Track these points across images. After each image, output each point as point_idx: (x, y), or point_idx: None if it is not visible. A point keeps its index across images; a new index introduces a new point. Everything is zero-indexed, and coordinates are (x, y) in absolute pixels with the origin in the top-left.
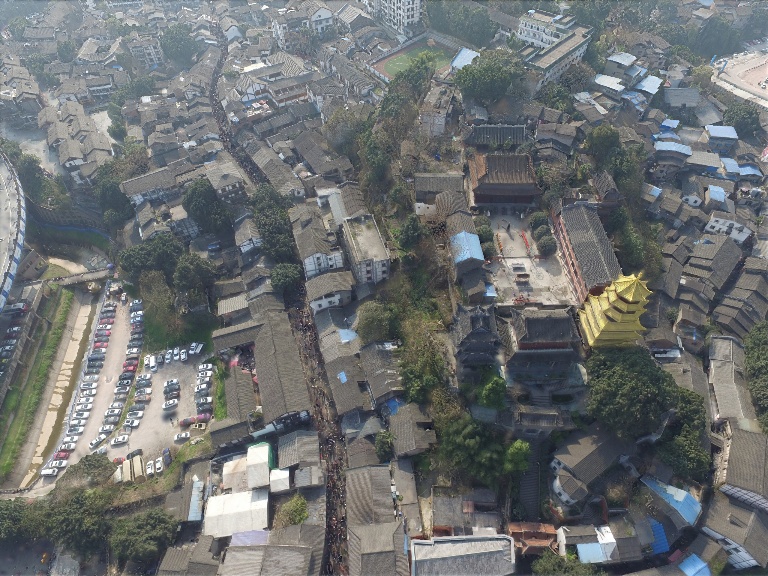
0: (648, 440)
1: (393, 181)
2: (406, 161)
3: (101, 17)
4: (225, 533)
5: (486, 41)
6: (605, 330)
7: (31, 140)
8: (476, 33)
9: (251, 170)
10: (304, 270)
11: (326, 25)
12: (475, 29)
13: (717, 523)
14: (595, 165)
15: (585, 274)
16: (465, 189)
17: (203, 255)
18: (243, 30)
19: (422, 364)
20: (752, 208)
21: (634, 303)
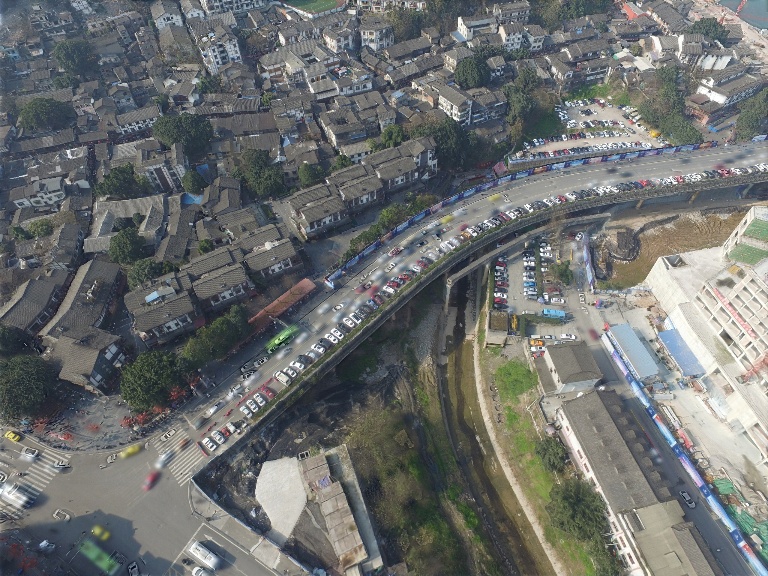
0: None
1: None
2: None
3: None
4: (652, 65)
5: None
6: None
7: (331, 249)
8: None
9: None
10: None
11: None
12: None
13: None
14: None
15: None
16: None
17: None
18: (165, 101)
19: None
20: None
21: None
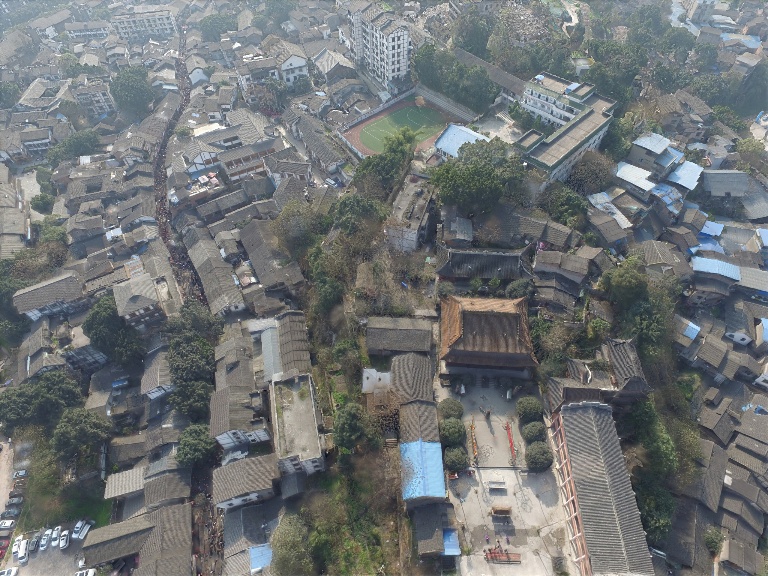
0: None
1: (344, 319)
2: (360, 298)
3: (59, 50)
4: None
5: (484, 107)
6: None
7: None
8: (472, 97)
9: (188, 265)
10: None
11: (299, 74)
12: (471, 92)
13: None
14: (612, 319)
15: (590, 544)
16: (436, 340)
17: (102, 400)
18: (209, 73)
19: None
20: None
21: None
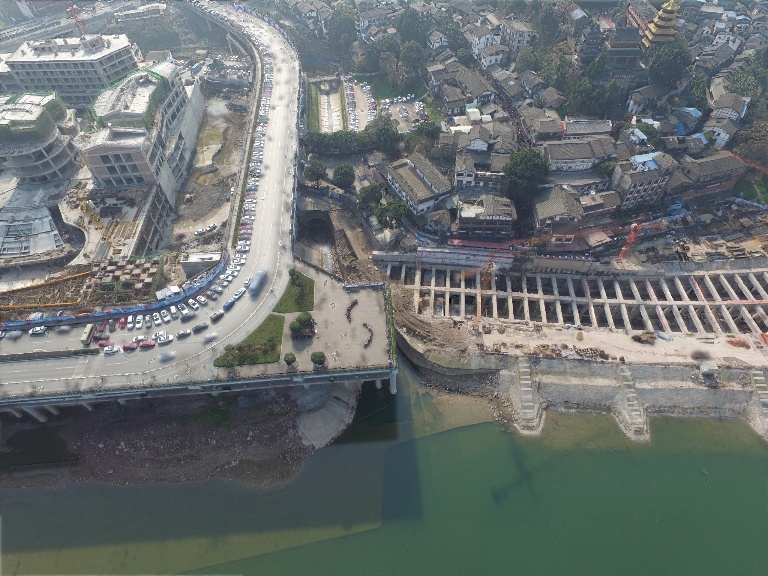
0: (676, 94)
1: (526, 5)
2: None
3: None
4: None
5: None
6: (656, 33)
7: None
8: None
9: None
10: (473, 55)
11: None
12: None
13: (709, 124)
14: None
15: None
16: None
17: None
18: None
19: (558, 66)
20: (743, 37)
21: (671, 13)
